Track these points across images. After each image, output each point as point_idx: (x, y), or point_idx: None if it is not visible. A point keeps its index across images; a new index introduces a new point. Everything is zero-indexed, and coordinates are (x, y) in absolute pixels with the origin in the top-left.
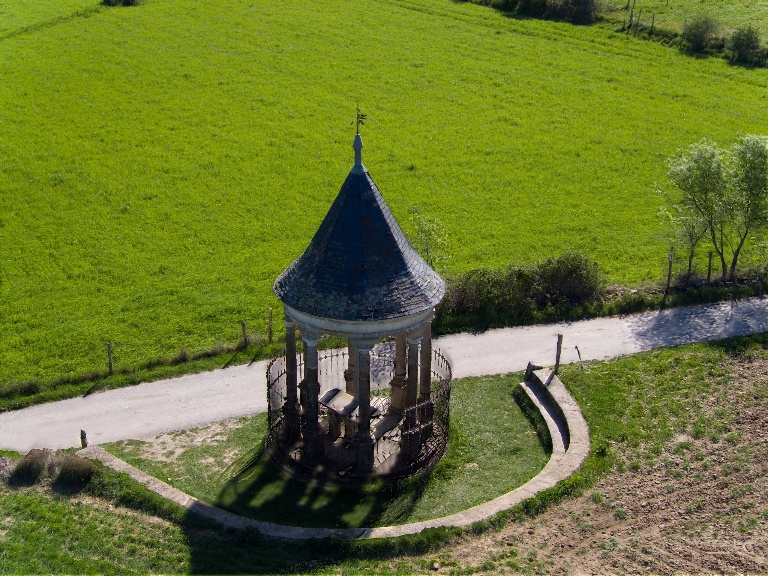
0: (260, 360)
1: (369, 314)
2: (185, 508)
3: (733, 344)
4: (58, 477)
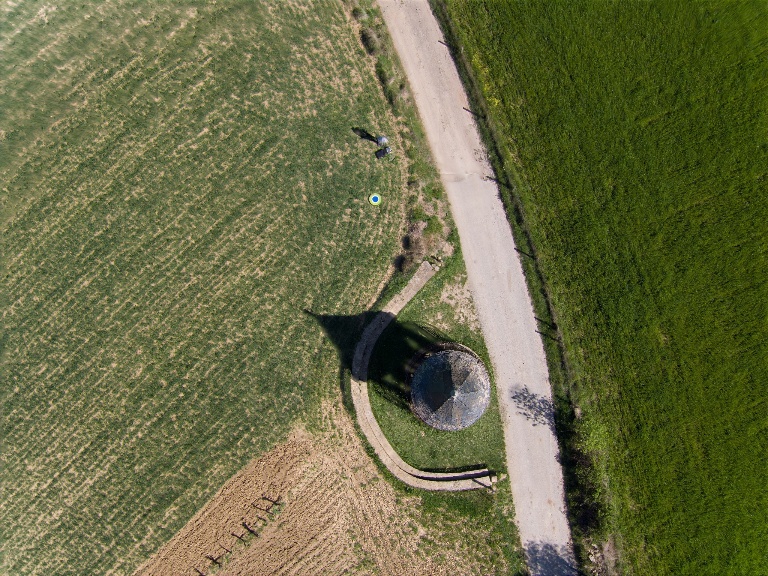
0: (541, 337)
1: (413, 392)
2: (378, 312)
3: None
4: (403, 257)
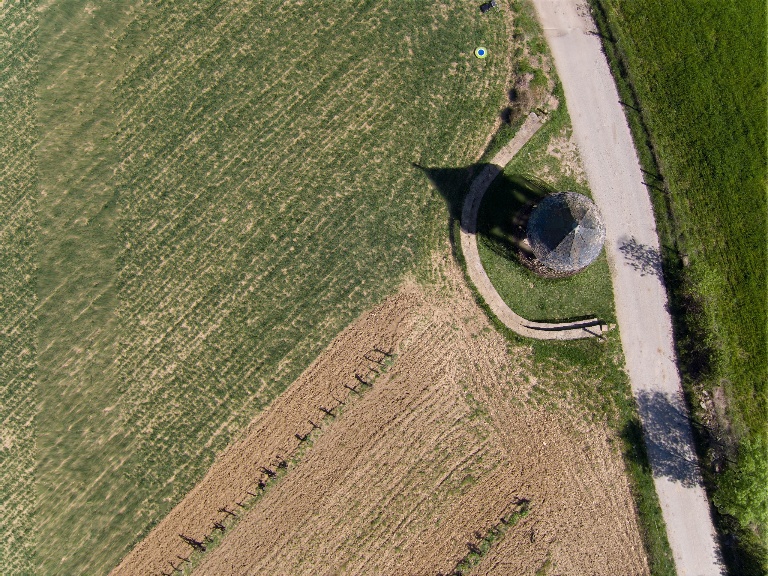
0: (648, 188)
1: (529, 233)
2: (486, 163)
3: (624, 437)
4: (510, 109)
